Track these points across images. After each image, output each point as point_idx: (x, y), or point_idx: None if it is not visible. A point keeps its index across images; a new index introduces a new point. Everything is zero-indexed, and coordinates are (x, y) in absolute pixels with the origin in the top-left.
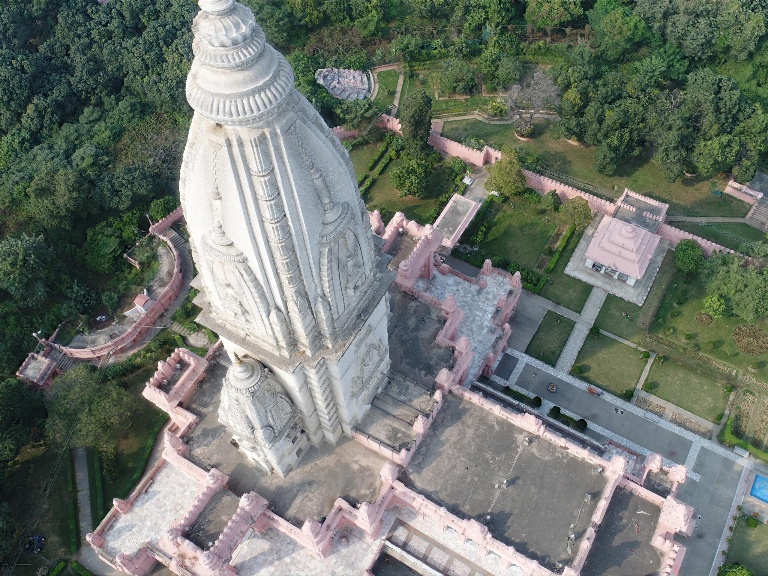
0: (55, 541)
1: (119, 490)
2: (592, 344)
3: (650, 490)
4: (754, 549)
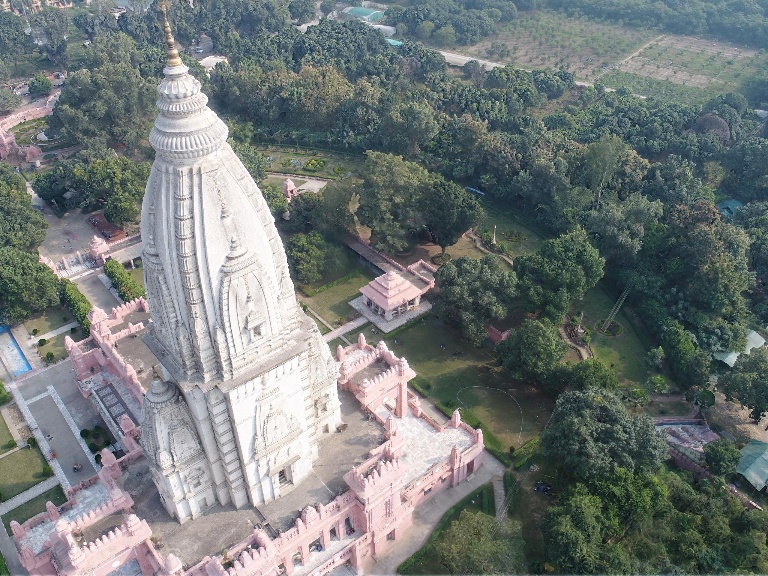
0: (526, 486)
1: (469, 507)
2: (11, 493)
3: (95, 347)
4: (64, 349)
